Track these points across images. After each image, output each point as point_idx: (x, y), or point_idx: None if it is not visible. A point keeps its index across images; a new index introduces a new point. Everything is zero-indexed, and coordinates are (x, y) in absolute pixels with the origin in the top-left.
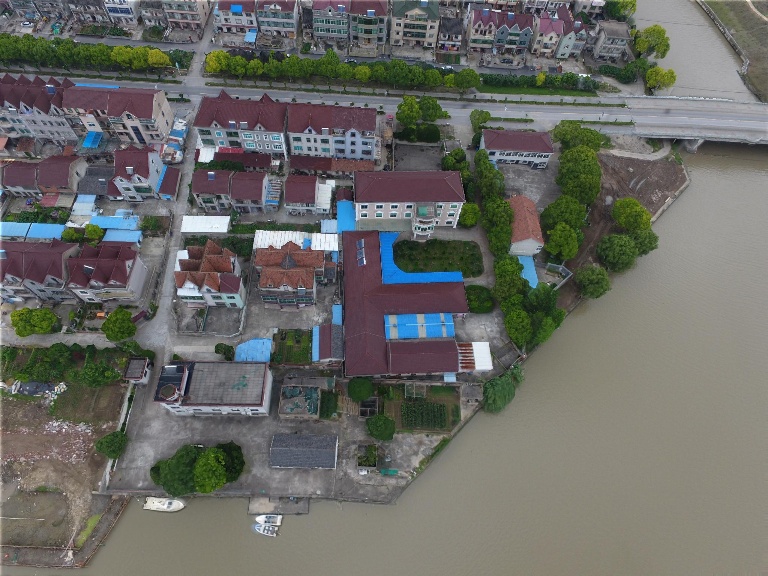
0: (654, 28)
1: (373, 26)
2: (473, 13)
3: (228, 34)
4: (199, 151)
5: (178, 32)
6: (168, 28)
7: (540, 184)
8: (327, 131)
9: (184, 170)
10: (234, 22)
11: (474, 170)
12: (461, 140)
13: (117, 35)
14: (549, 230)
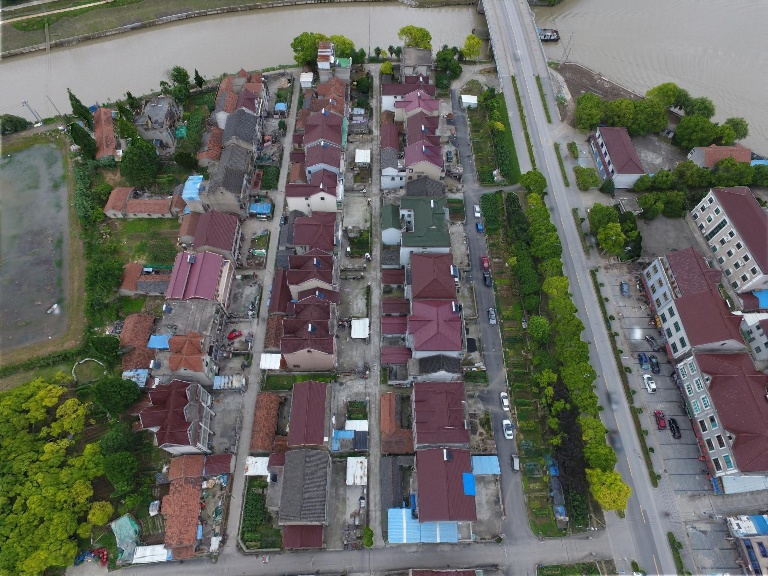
0: (416, 30)
1: None
2: (428, 162)
3: None
4: None
5: None
6: None
7: None
8: None
9: None
10: None
11: None
12: (603, 203)
13: None
14: (715, 143)
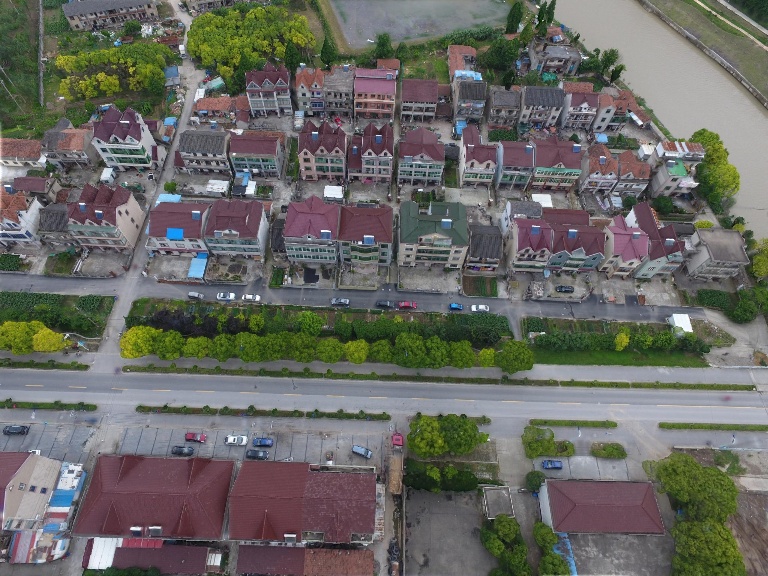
0: None
1: (372, 253)
2: (517, 231)
3: (168, 257)
4: (92, 543)
5: (97, 257)
6: (83, 252)
7: (640, 570)
8: (294, 538)
9: (68, 573)
10: (174, 246)
11: (533, 546)
12: (508, 471)
13: (8, 270)
14: None
